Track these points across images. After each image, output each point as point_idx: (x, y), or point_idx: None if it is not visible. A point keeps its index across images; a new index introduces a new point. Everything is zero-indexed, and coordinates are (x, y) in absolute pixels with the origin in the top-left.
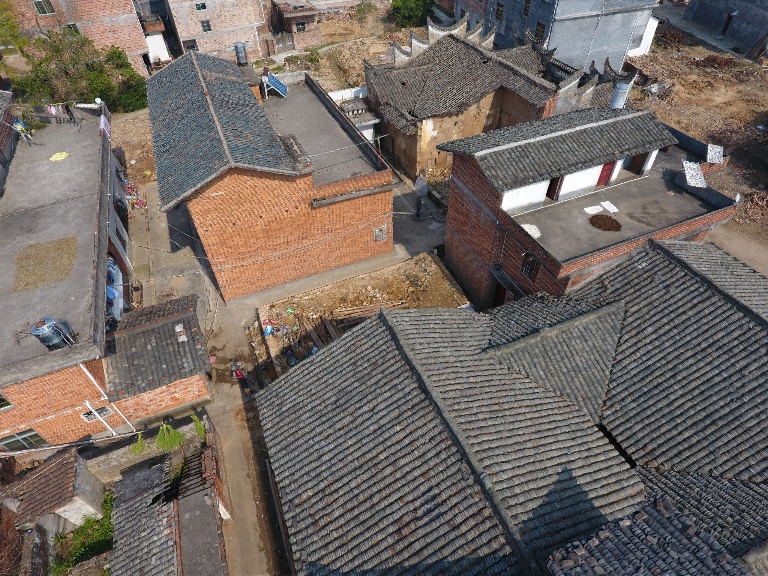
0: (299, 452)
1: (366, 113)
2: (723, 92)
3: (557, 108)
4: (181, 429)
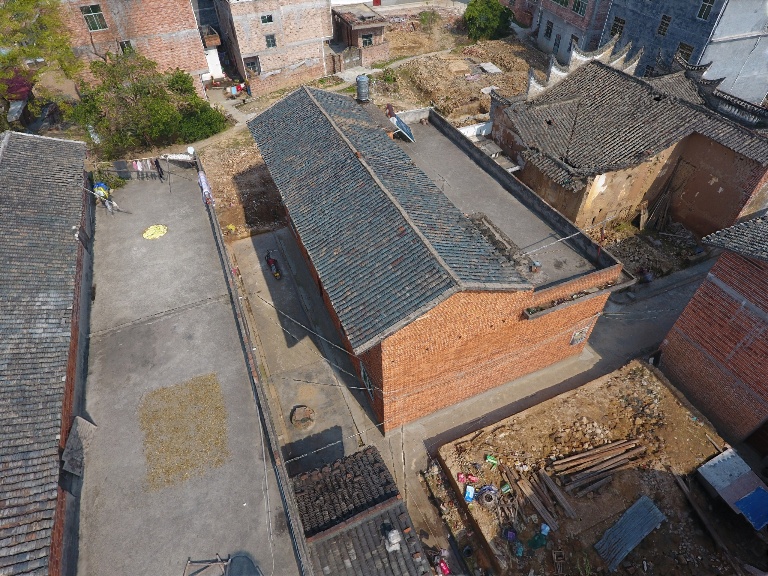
0: None
1: (499, 157)
2: None
3: None
4: None
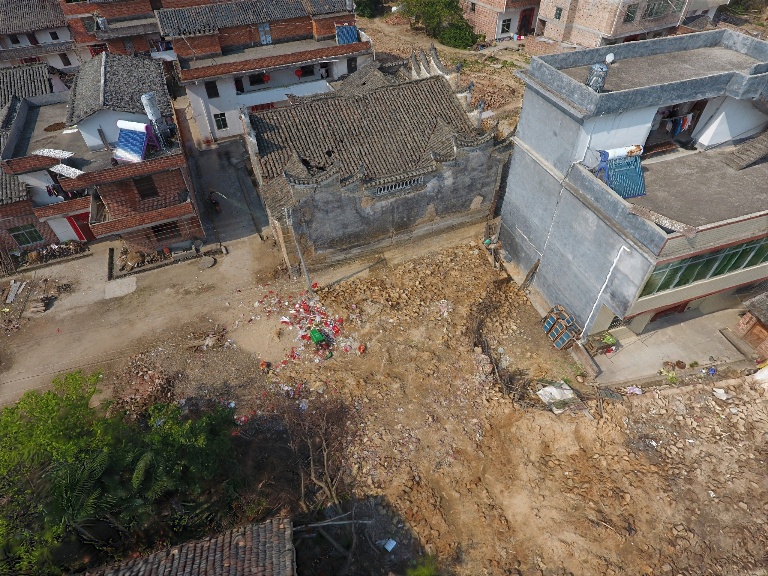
0: None
1: None
2: (558, 531)
3: None
4: None
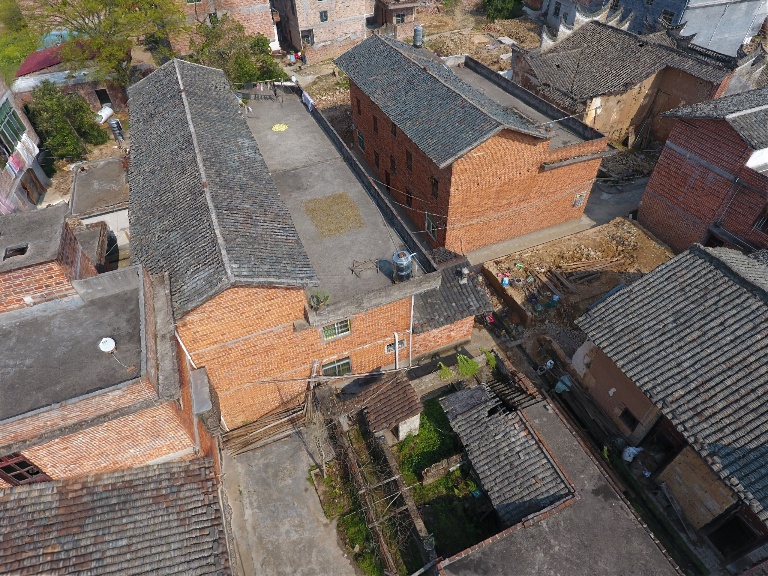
0: (652, 362)
1: None
2: None
3: (729, 86)
4: (476, 359)
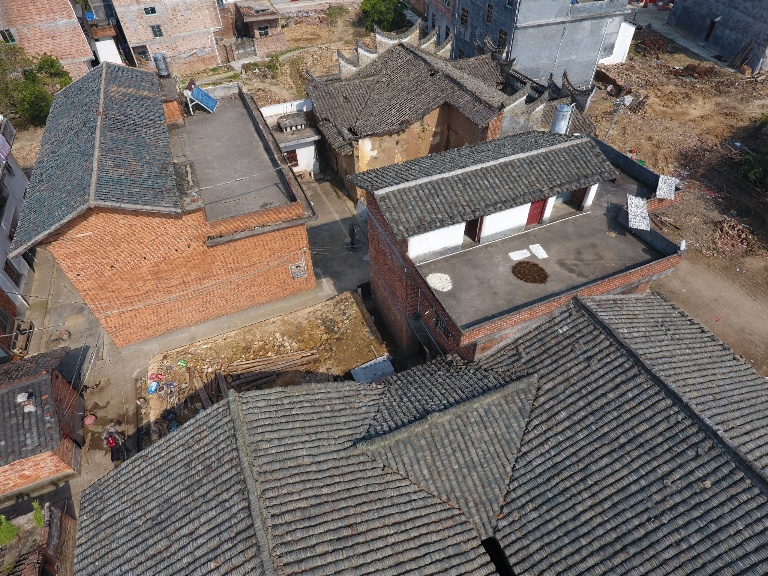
0: None
1: (306, 129)
2: (700, 105)
3: (503, 128)
4: (17, 520)
